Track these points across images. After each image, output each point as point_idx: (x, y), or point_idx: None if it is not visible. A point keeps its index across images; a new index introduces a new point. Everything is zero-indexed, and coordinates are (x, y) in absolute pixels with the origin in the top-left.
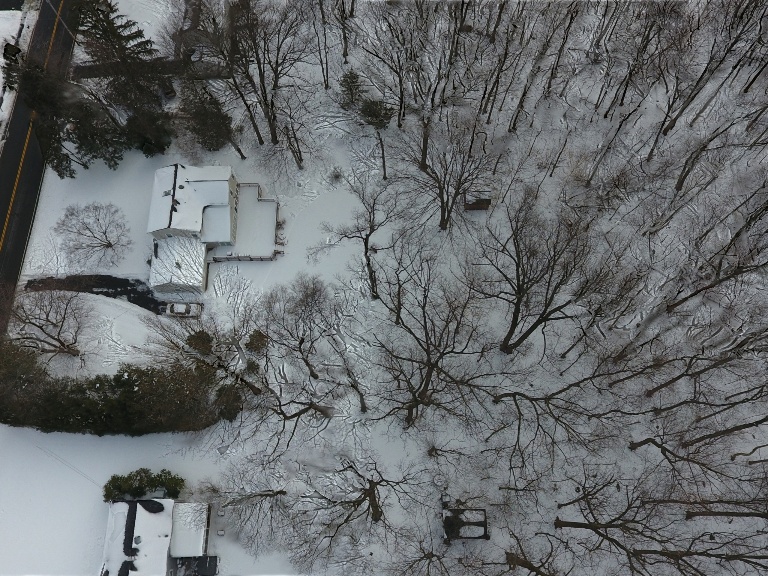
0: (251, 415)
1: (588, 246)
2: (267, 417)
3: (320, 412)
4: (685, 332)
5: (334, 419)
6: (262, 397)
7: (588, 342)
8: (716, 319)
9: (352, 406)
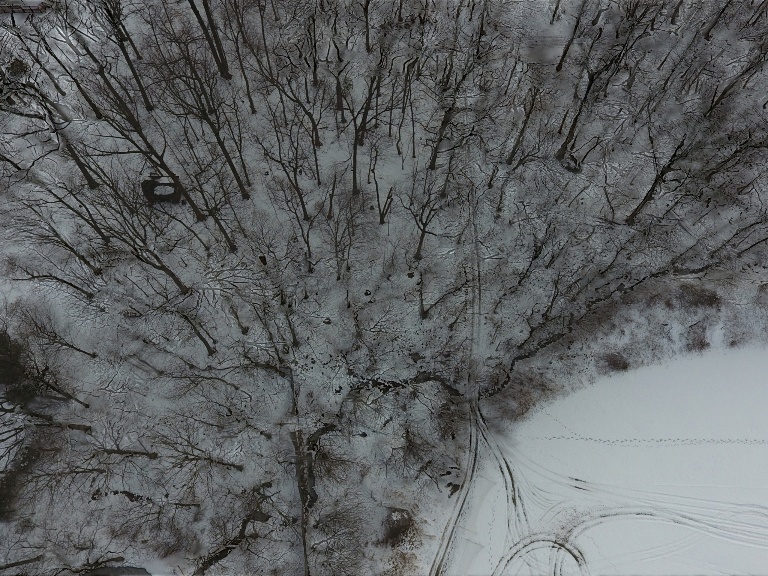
0: (5, 119)
1: (309, 3)
2: (15, 117)
3: (54, 108)
4: (377, 64)
5: (73, 122)
6: (16, 107)
7: (294, 69)
8: (403, 53)
9: (83, 106)
